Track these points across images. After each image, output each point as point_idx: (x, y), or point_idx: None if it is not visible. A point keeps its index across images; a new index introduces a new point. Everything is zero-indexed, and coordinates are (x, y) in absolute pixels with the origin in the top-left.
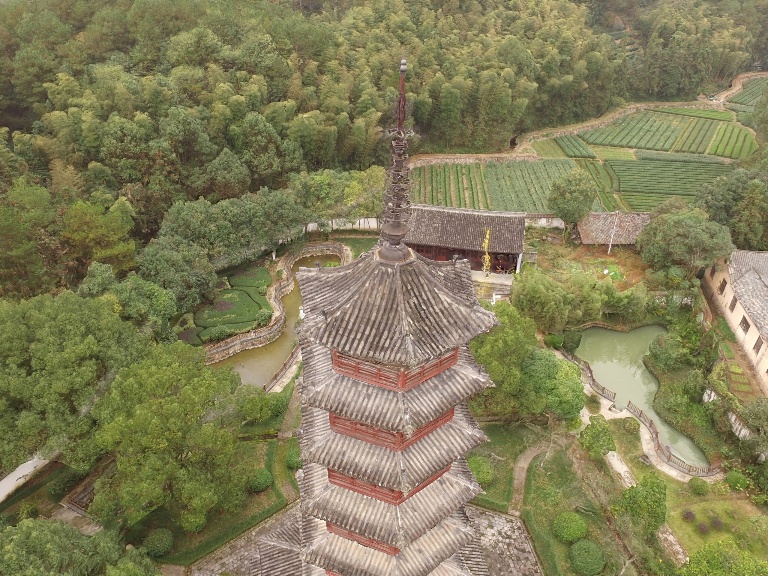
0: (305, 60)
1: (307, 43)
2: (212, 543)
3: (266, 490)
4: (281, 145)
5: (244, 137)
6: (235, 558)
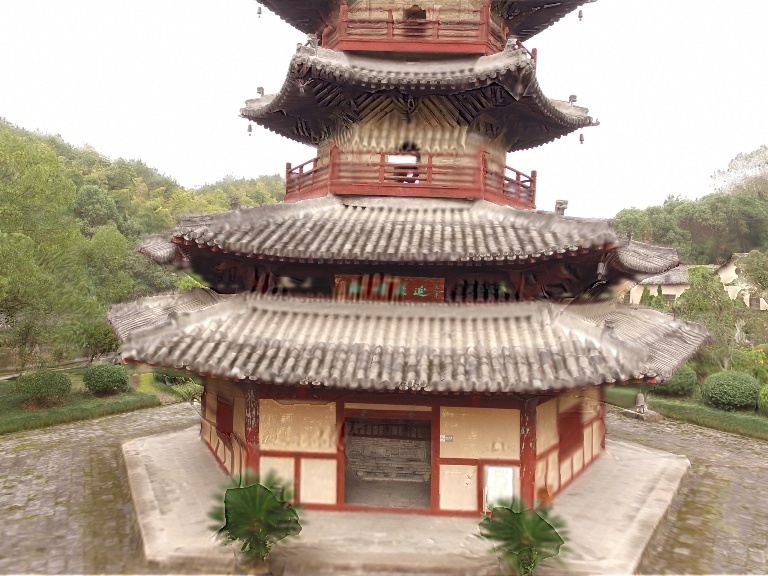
0: (150, 190)
1: (152, 181)
2: (1, 421)
3: (117, 394)
4: (123, 223)
5: (78, 206)
6: (55, 434)
